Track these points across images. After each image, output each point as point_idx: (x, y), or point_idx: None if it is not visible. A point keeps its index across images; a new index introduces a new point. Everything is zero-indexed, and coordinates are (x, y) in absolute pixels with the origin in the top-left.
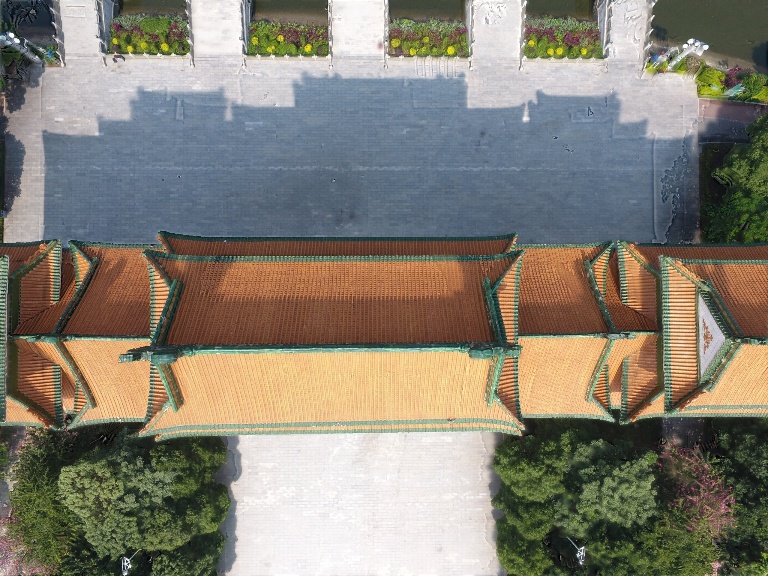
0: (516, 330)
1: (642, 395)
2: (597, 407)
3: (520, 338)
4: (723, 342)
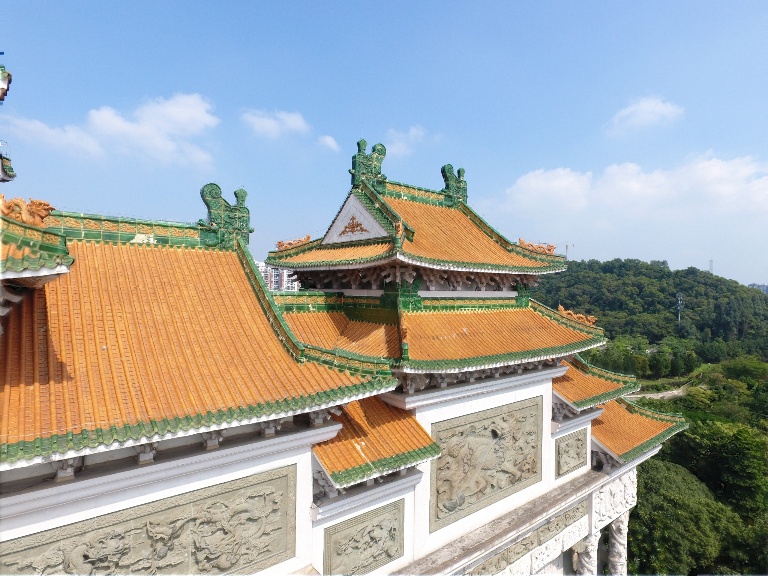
0: None
1: (394, 342)
2: (338, 373)
3: None
4: (354, 196)
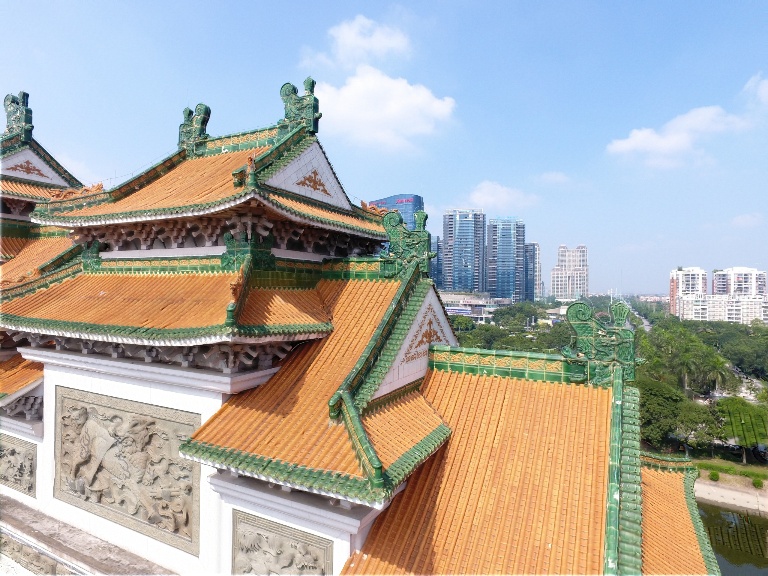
0: None
1: None
2: None
3: None
4: None
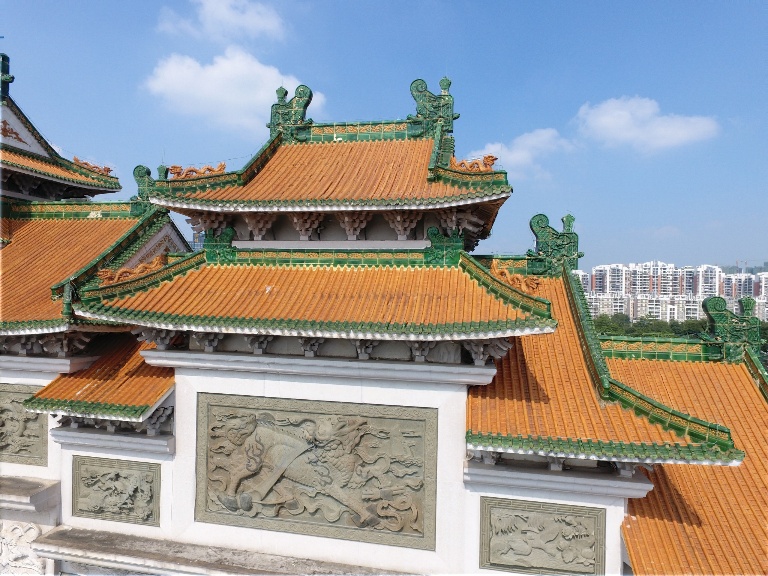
0: None
1: None
2: None
3: (44, 222)
4: None
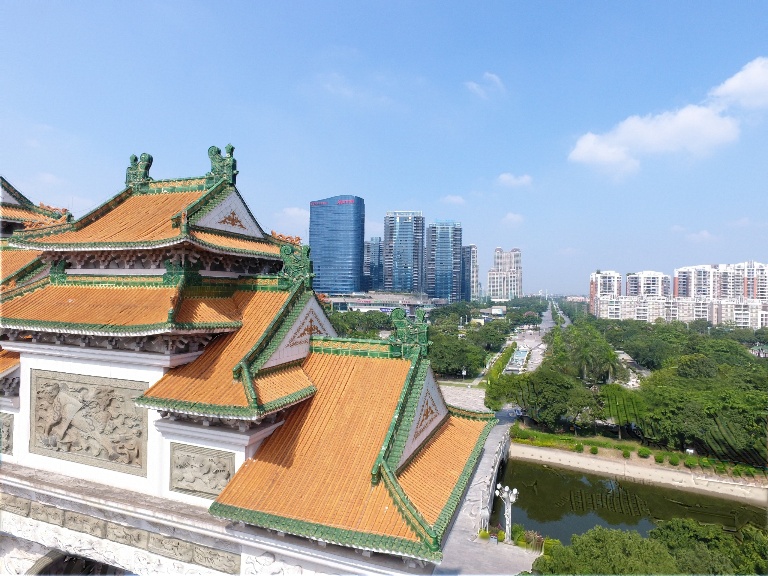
0: (4, 217)
1: None
2: None
3: None
4: None
